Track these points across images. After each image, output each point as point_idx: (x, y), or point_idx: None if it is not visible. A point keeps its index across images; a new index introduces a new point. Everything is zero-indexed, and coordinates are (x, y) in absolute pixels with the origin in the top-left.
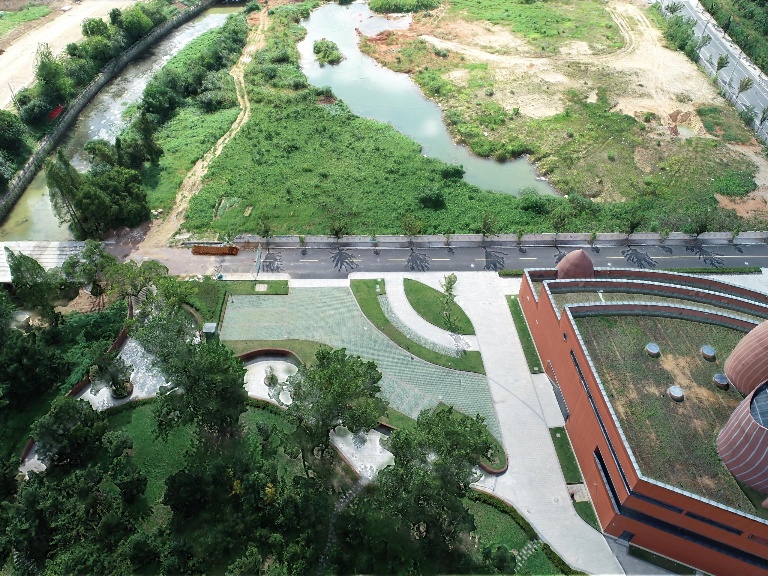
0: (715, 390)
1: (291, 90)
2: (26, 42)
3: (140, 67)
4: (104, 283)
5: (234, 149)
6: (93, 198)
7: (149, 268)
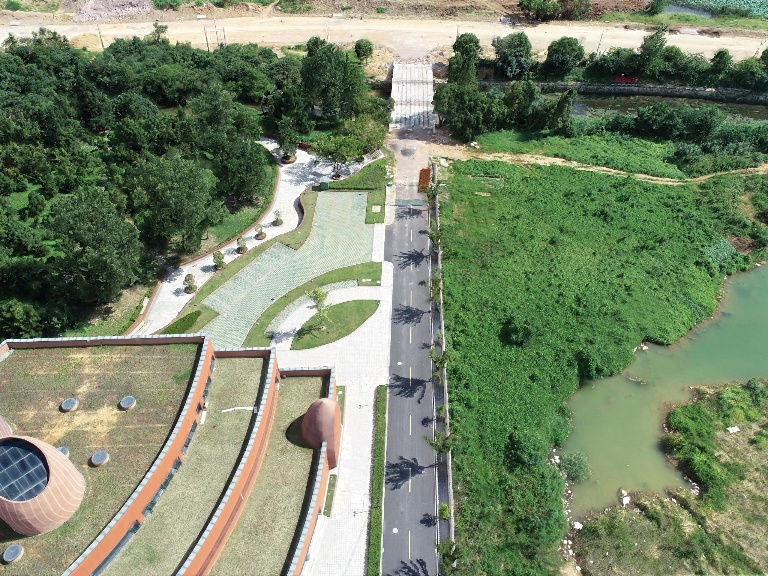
0: (55, 446)
1: (752, 213)
2: (745, 43)
3: (756, 113)
4: (389, 136)
5: (587, 177)
6: (441, 91)
7: (372, 134)
